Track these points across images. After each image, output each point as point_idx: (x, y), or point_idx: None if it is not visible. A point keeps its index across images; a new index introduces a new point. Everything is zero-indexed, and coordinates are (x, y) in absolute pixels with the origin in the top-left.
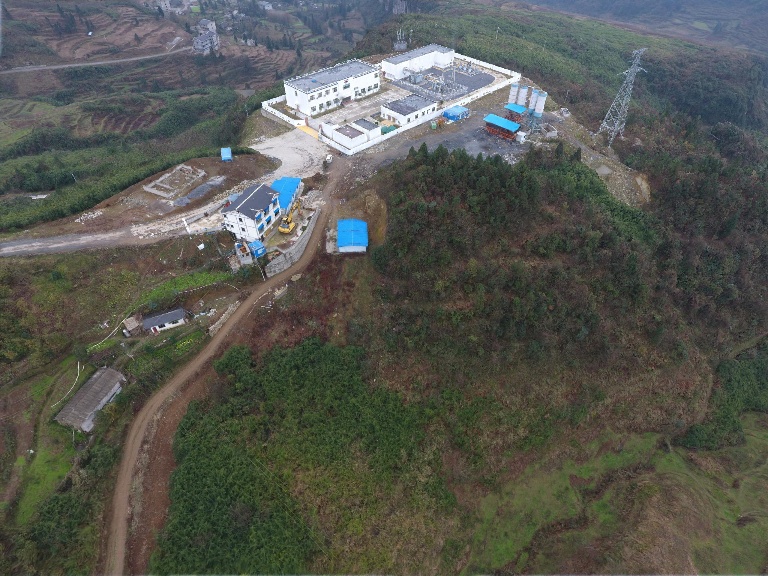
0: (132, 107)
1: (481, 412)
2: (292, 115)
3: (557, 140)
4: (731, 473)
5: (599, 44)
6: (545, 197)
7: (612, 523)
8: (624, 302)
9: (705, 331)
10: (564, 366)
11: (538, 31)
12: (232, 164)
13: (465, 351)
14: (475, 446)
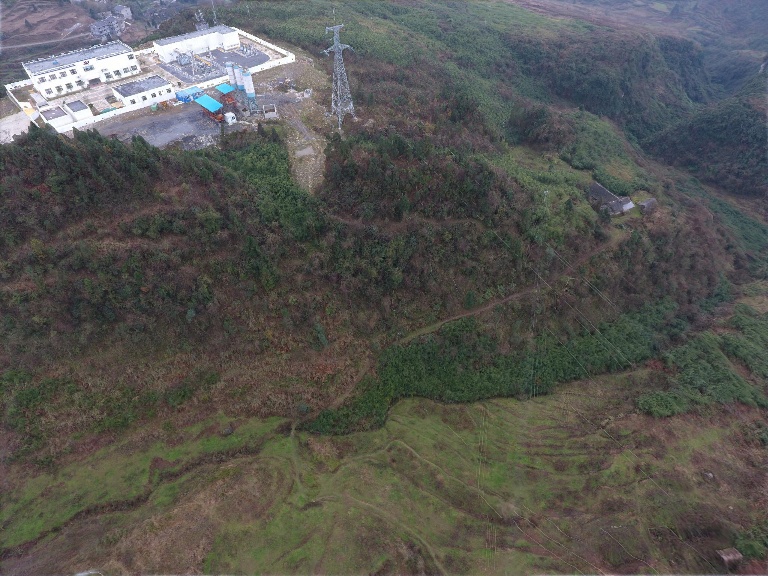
0: None
1: (48, 394)
2: (29, 98)
3: (274, 121)
4: (342, 458)
5: (478, 25)
6: (173, 178)
7: (163, 506)
8: (250, 285)
9: (370, 315)
10: (176, 349)
11: (412, 12)
12: None
13: (36, 333)
14: (31, 427)
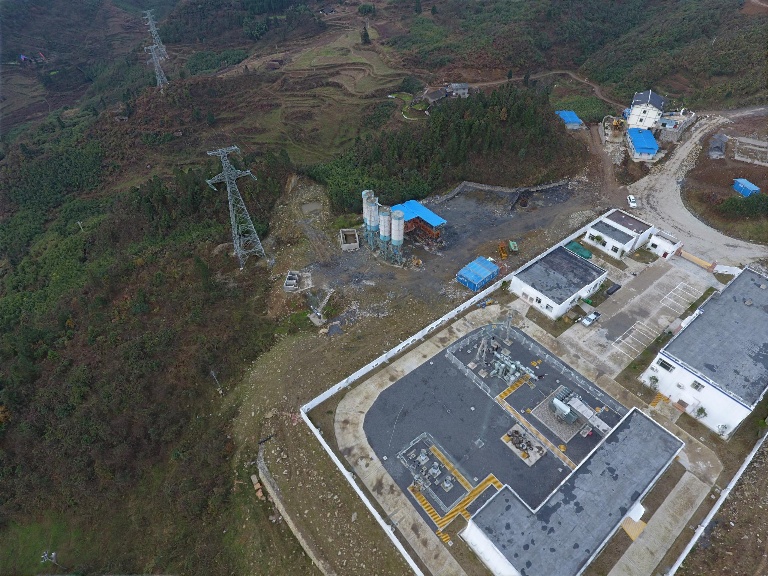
0: None
1: None
2: None
3: None
4: None
5: None
6: None
7: None
8: None
9: None
10: None
11: None
12: (721, 167)
13: None
14: None
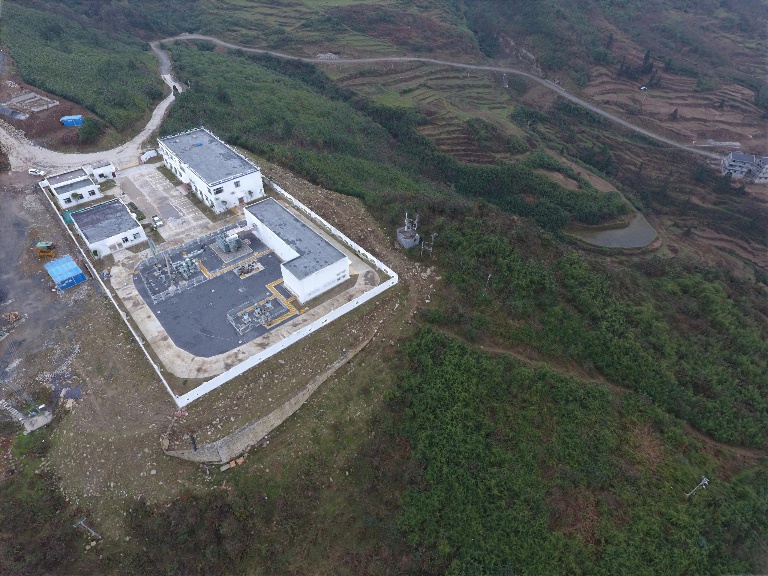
0: (496, 144)
1: None
2: None
3: None
4: None
5: None
6: None
7: None
8: None
9: None
10: None
11: None
12: (41, 119)
13: None
14: None
